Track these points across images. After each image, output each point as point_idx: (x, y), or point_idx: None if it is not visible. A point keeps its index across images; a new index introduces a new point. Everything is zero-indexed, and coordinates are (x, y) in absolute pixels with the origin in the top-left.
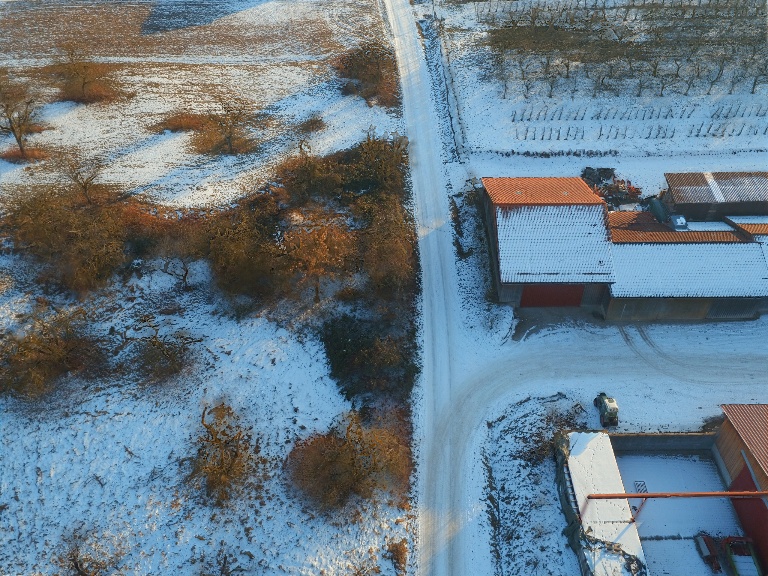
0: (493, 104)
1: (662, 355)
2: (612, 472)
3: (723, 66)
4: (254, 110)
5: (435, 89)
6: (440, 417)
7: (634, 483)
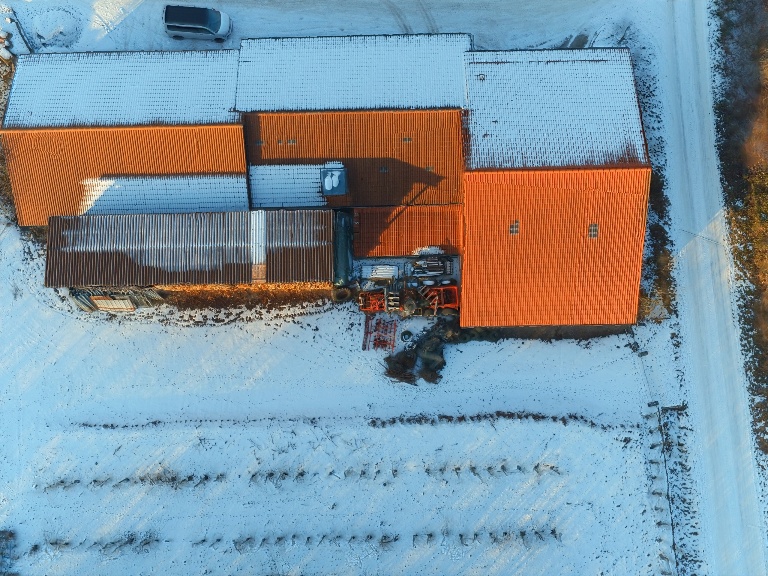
0: None
1: (398, 11)
2: None
3: None
4: None
5: None
6: None
7: None
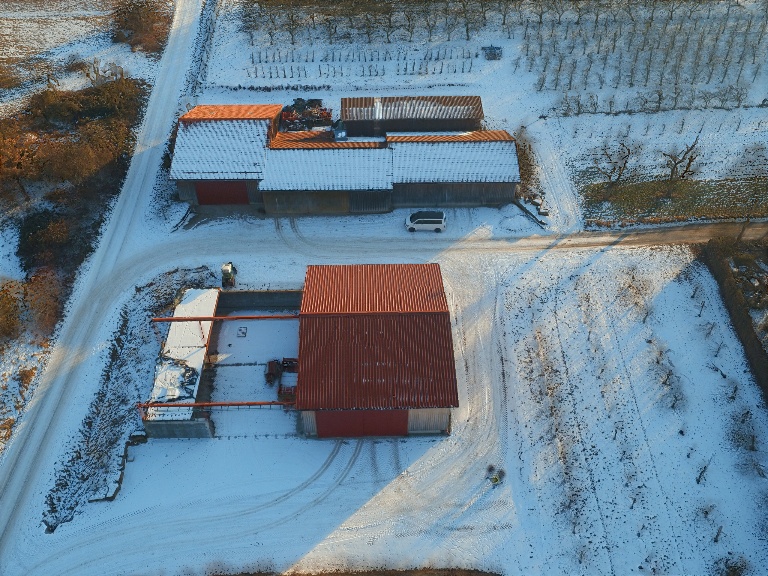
0: (241, 50)
1: (301, 238)
2: (207, 315)
3: (436, 15)
4: (30, 55)
5: (199, 39)
6: (98, 283)
7: (238, 329)
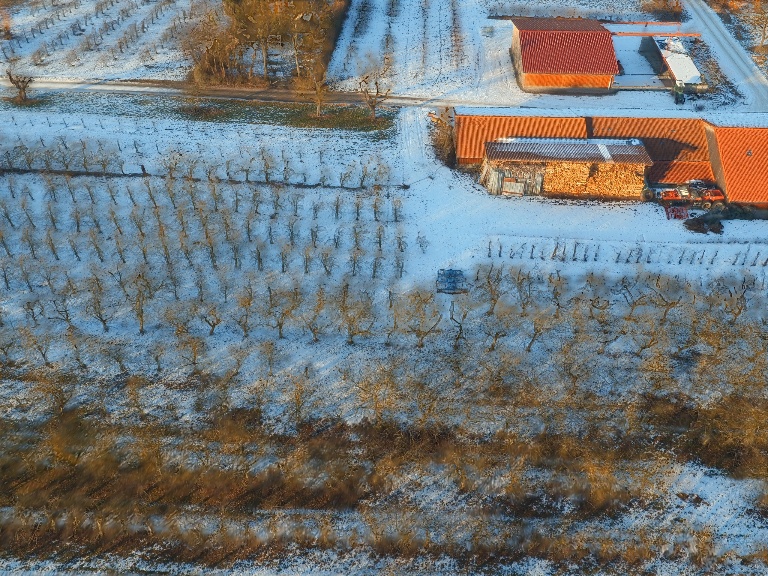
0: None
1: None
2: None
3: None
4: None
5: None
6: None
7: None
